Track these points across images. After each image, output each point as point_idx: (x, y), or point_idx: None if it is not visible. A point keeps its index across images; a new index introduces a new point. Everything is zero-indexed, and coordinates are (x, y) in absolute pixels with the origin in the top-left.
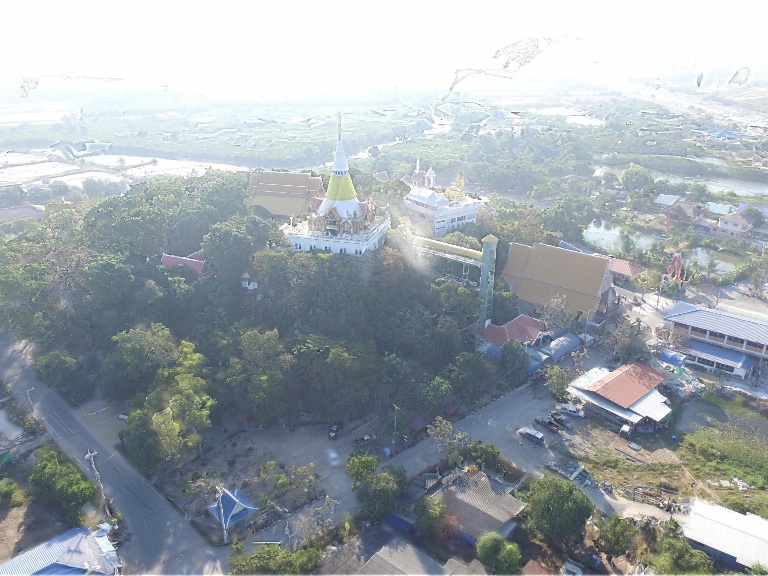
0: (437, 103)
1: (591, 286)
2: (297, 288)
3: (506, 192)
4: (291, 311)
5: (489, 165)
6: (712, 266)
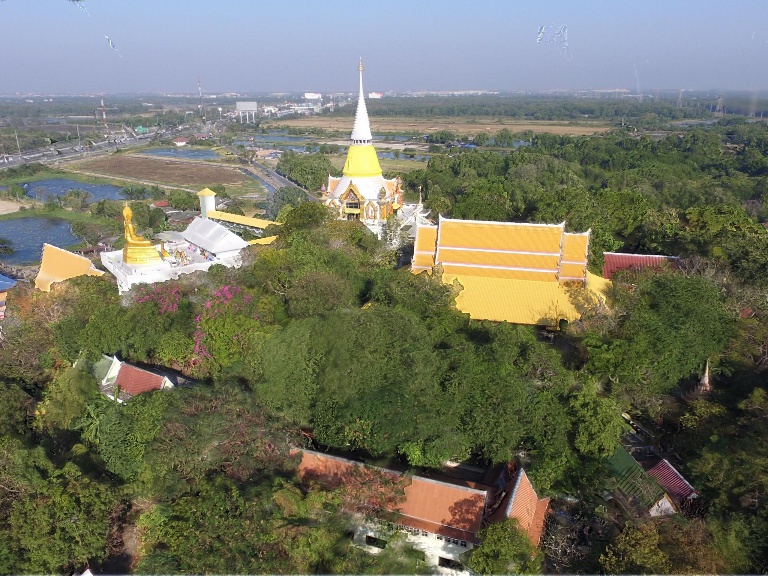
0: None
1: None
2: None
3: None
4: None
5: None
6: None
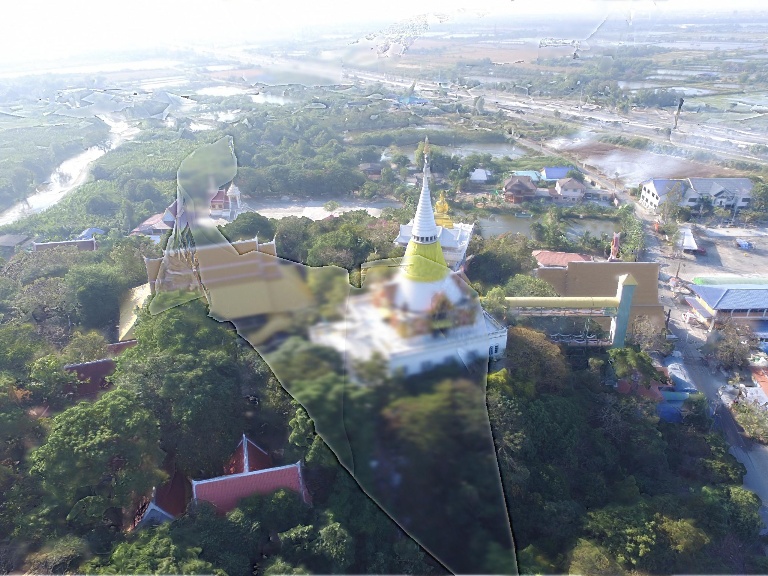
0: (81, 94)
1: (648, 296)
2: None
3: (322, 196)
4: (516, 488)
5: (288, 168)
6: (624, 237)
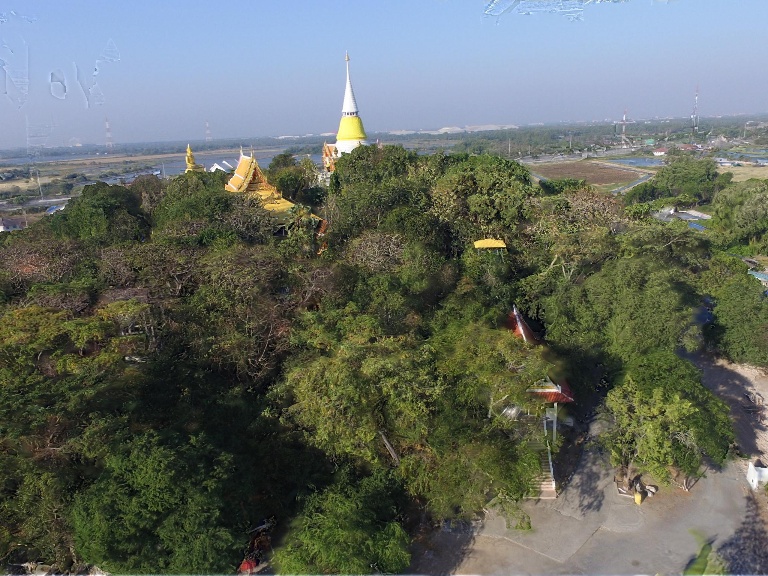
0: None
1: None
2: None
3: None
4: None
5: None
6: None
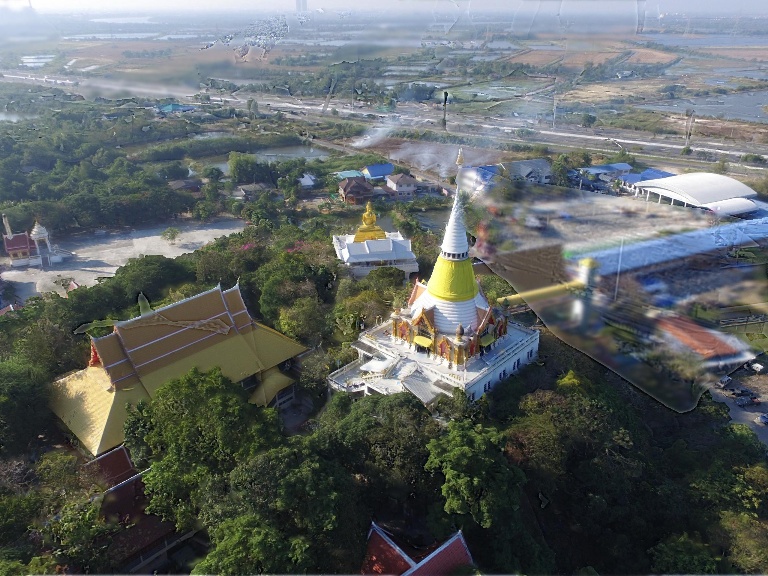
0: None
1: None
2: (618, 446)
3: (145, 224)
4: None
5: (94, 196)
6: None
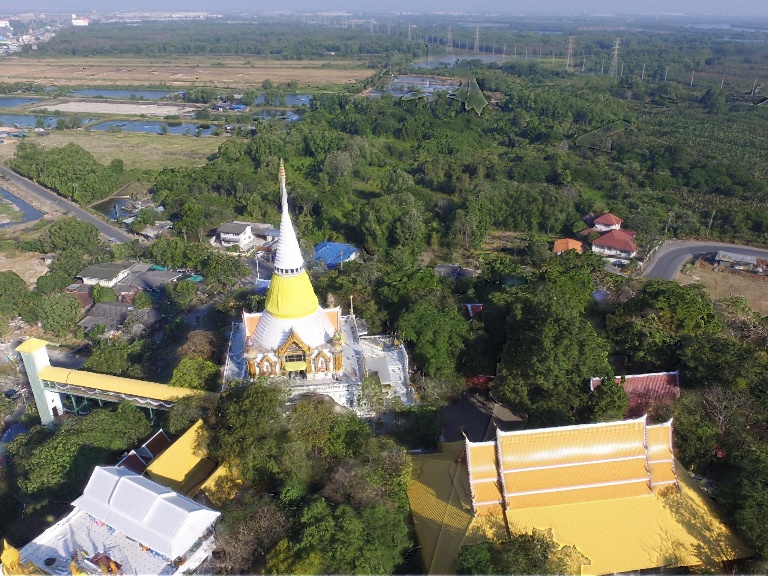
0: None
1: None
2: None
3: None
4: None
5: None
6: None
